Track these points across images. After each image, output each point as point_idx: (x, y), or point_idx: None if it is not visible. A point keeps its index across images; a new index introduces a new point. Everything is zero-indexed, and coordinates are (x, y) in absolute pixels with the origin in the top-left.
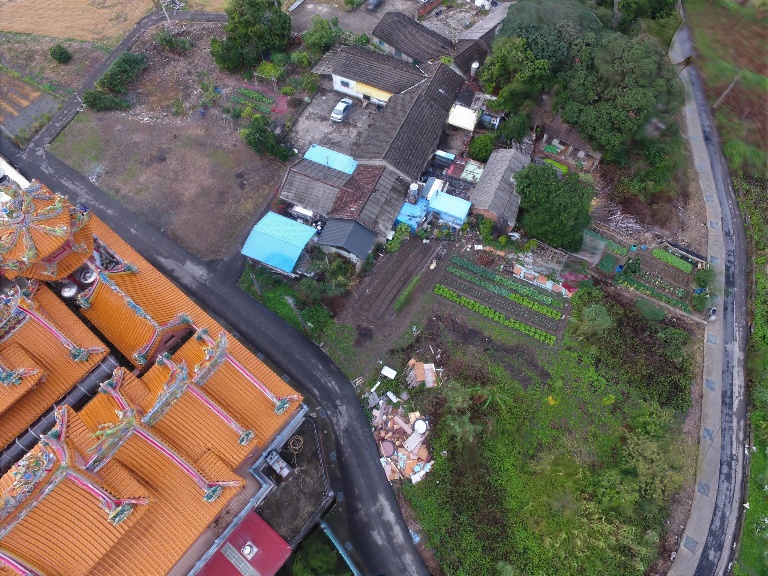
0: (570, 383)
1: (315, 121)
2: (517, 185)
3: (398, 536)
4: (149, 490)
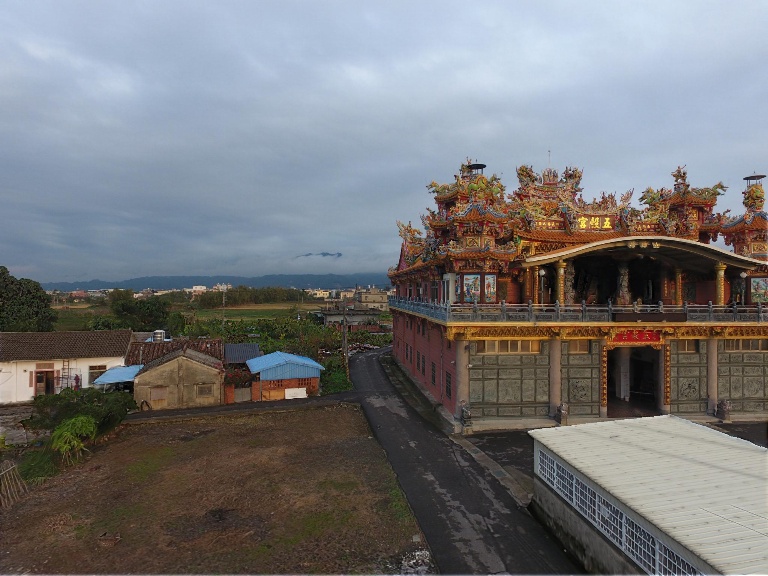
0: None
1: None
2: None
3: None
4: None
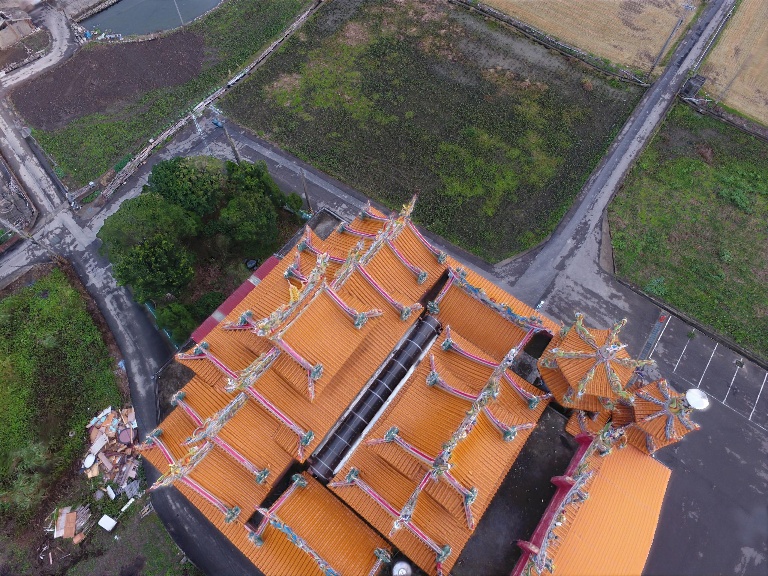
0: None
1: None
2: None
3: (135, 365)
4: None
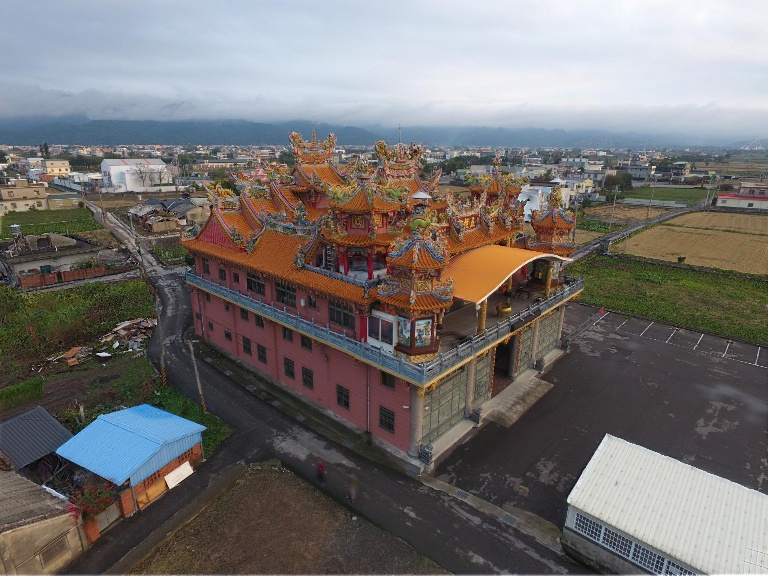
0: None
1: None
2: None
3: None
4: None
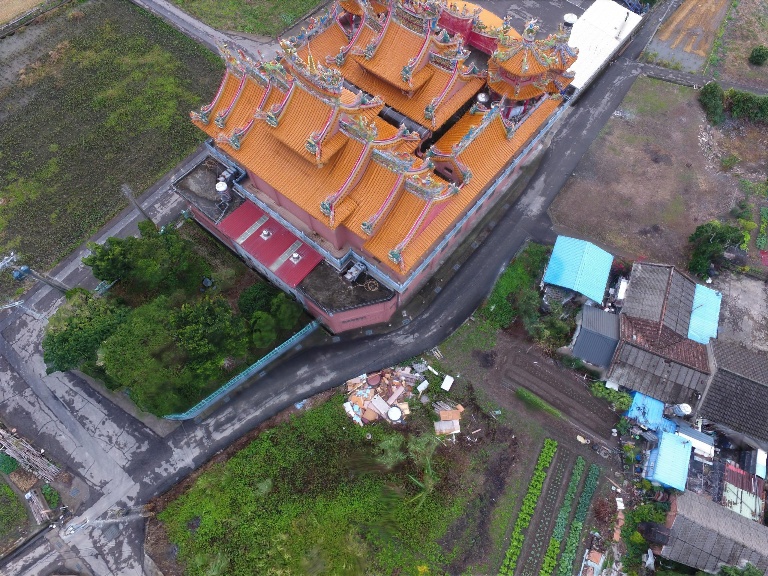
0: None
1: (764, 299)
2: (736, 569)
3: (302, 389)
4: (330, 169)
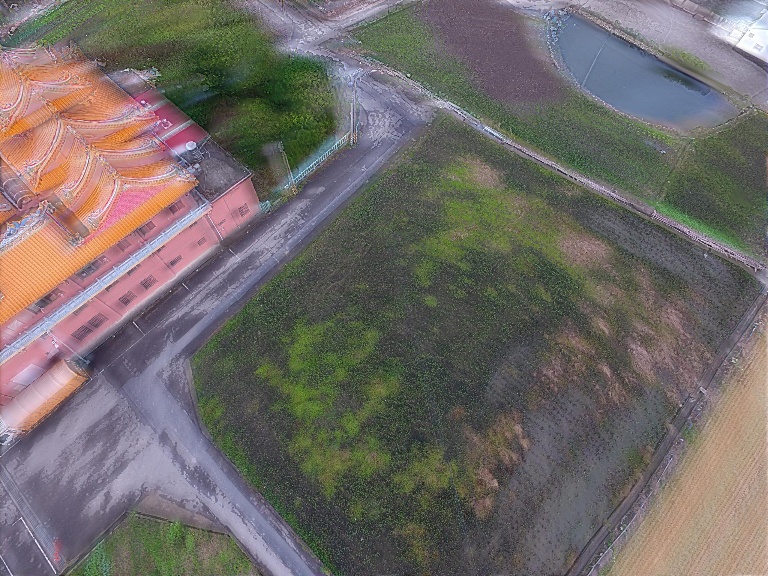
0: (133, 4)
1: None
2: None
3: None
4: None
